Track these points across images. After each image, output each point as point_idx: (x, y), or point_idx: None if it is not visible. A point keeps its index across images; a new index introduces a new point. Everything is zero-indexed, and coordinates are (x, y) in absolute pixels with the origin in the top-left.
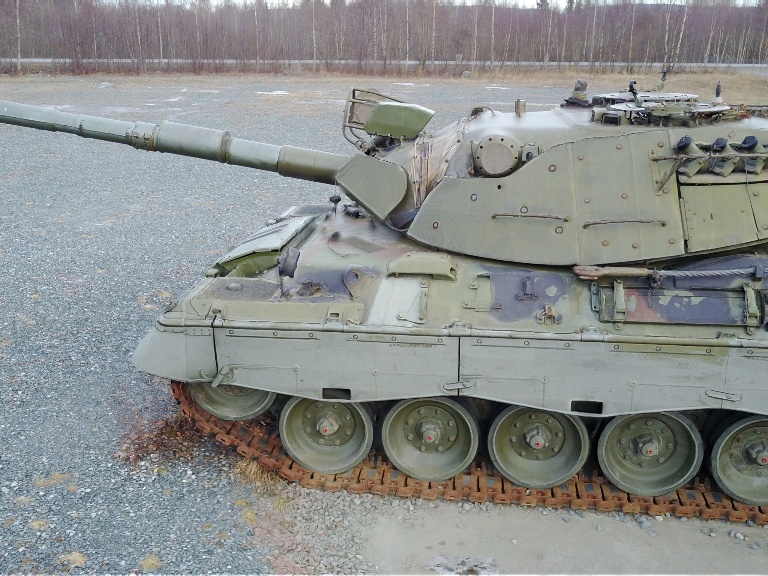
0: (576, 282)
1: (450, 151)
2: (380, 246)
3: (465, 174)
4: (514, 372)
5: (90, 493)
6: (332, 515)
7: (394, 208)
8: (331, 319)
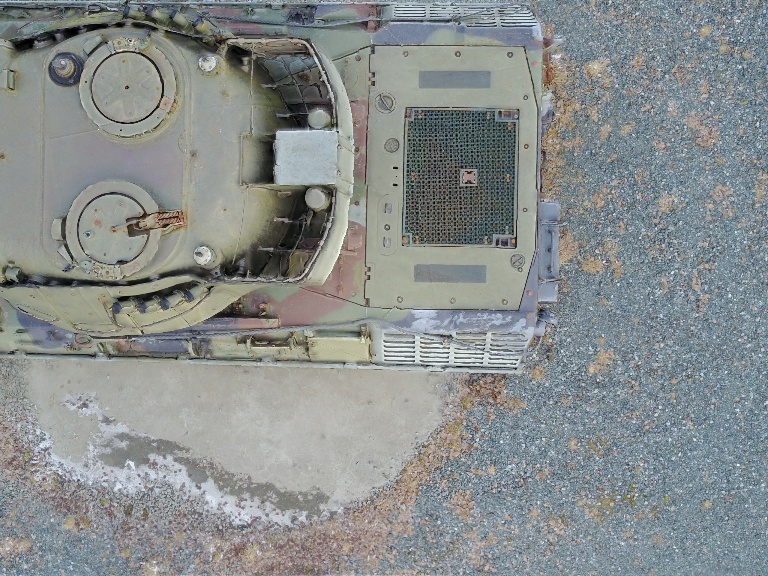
0: None
1: None
2: None
3: None
4: None
5: None
6: (5, 365)
7: None
8: None
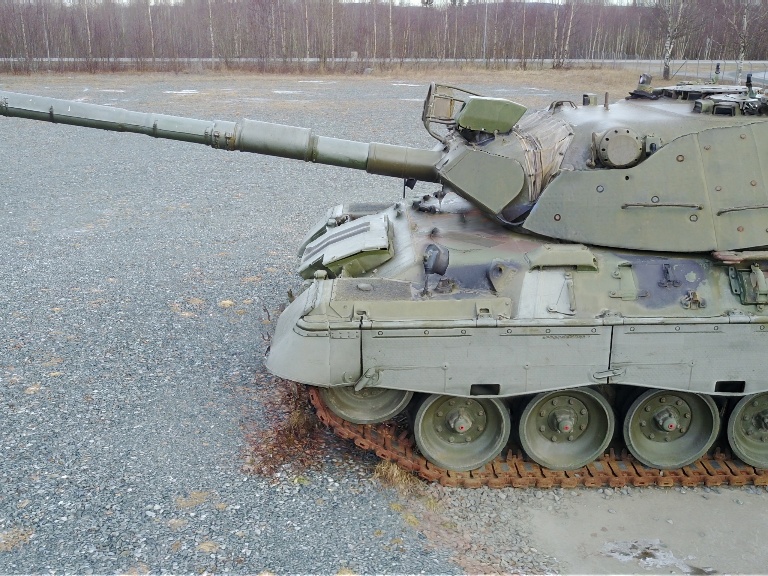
0: (713, 267)
1: (563, 144)
2: (494, 240)
3: (583, 166)
4: (664, 357)
5: (241, 510)
6: (485, 511)
7: (510, 202)
8: (483, 315)
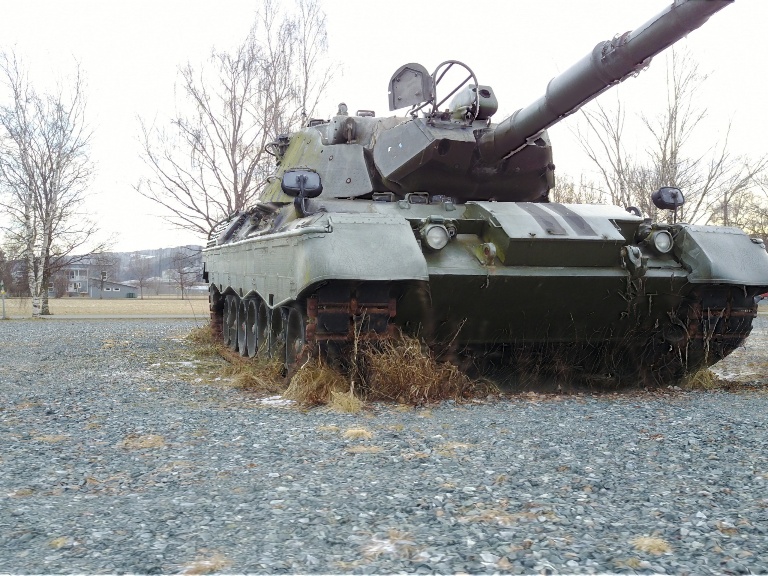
0: None
1: None
2: None
3: None
4: None
5: None
6: None
7: None
8: None
